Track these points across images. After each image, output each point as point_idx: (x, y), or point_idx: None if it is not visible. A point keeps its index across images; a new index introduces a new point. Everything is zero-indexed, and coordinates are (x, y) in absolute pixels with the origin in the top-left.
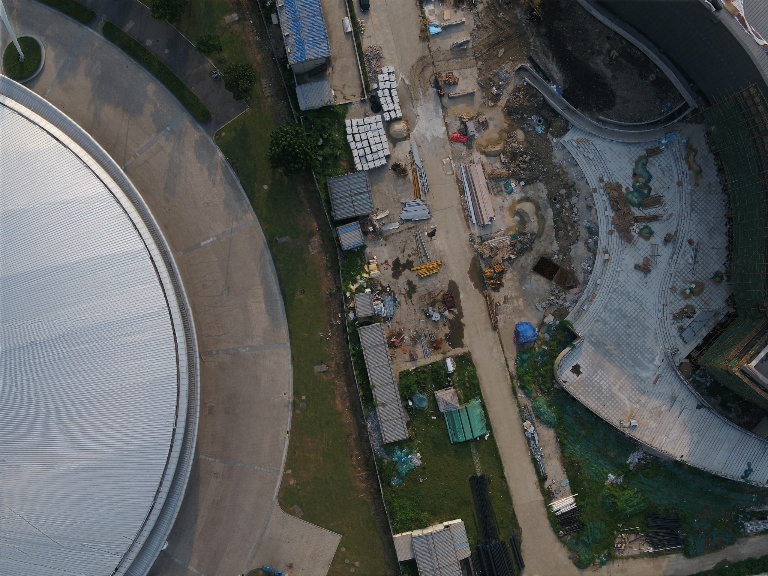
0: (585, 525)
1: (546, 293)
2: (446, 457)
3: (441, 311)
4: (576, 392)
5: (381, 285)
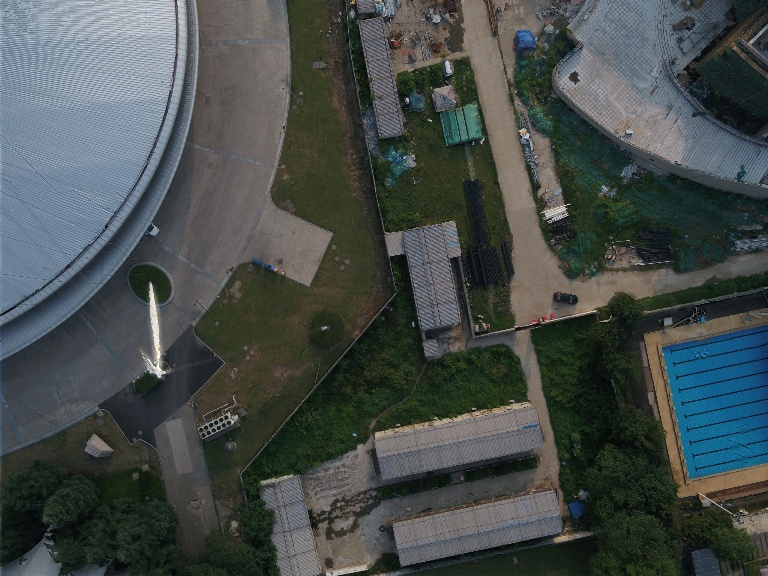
0: (576, 235)
1: (547, 2)
2: (441, 160)
3: (442, 14)
4: (573, 99)
5: None
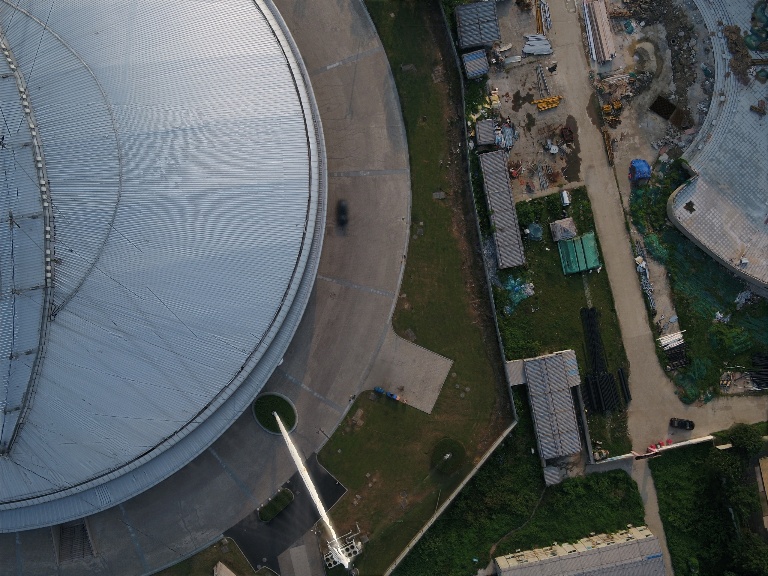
0: (692, 361)
1: (662, 132)
2: (558, 288)
3: (559, 144)
4: (689, 228)
5: (501, 117)
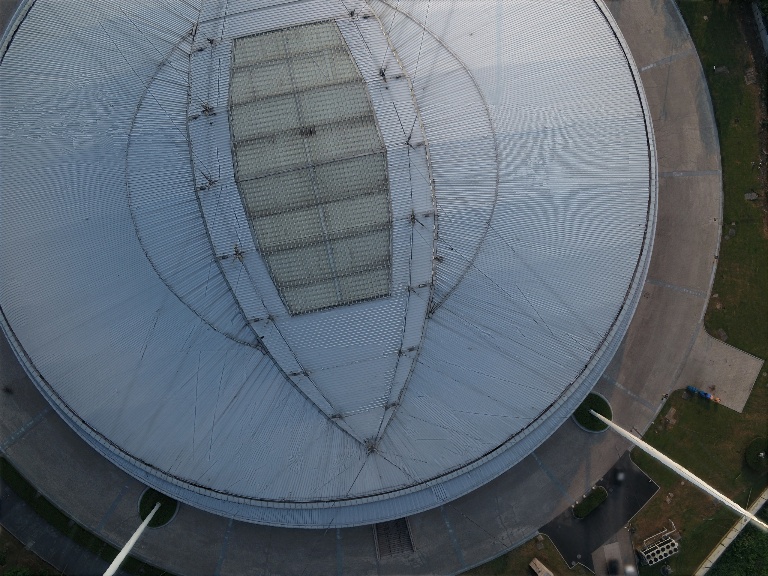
0: None
1: None
2: None
3: None
4: None
5: None
